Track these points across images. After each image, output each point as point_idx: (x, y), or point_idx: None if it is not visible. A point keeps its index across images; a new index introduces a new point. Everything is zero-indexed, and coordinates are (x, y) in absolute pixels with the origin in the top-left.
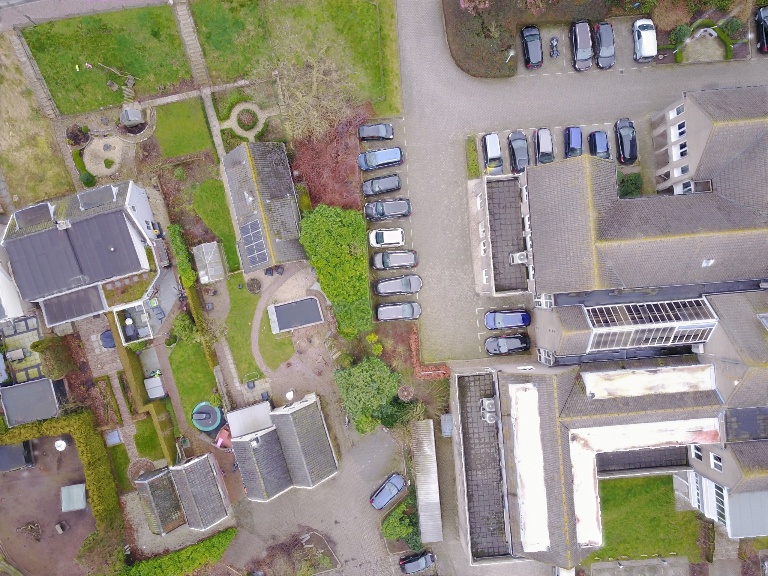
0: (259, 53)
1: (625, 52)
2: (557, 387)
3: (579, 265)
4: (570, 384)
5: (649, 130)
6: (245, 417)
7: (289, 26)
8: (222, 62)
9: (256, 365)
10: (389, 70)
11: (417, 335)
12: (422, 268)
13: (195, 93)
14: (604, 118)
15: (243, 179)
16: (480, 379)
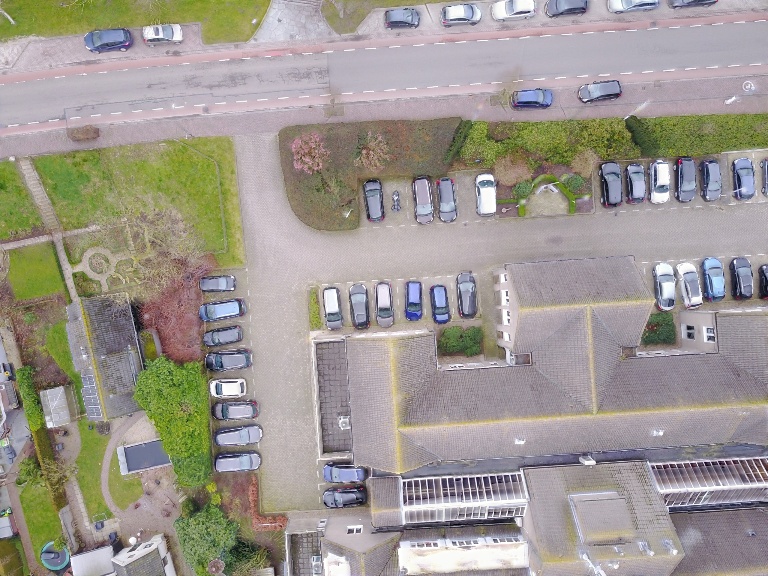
0: (107, 201)
1: (468, 205)
2: (366, 565)
3: (386, 446)
4: (386, 556)
5: (491, 284)
6: (88, 561)
7: (134, 178)
8: (71, 210)
9: (106, 505)
10: (231, 223)
11: (256, 486)
12: (264, 417)
13: (47, 237)
14: (447, 270)
15: (79, 334)
16: (313, 535)
